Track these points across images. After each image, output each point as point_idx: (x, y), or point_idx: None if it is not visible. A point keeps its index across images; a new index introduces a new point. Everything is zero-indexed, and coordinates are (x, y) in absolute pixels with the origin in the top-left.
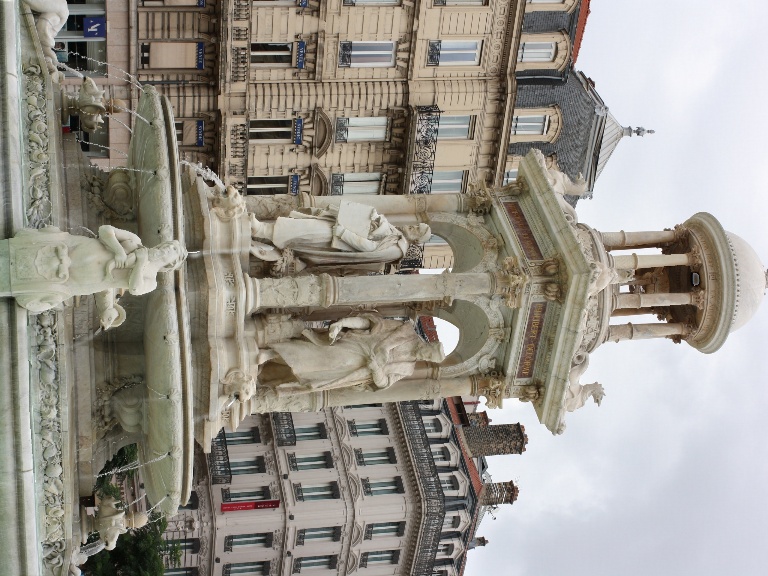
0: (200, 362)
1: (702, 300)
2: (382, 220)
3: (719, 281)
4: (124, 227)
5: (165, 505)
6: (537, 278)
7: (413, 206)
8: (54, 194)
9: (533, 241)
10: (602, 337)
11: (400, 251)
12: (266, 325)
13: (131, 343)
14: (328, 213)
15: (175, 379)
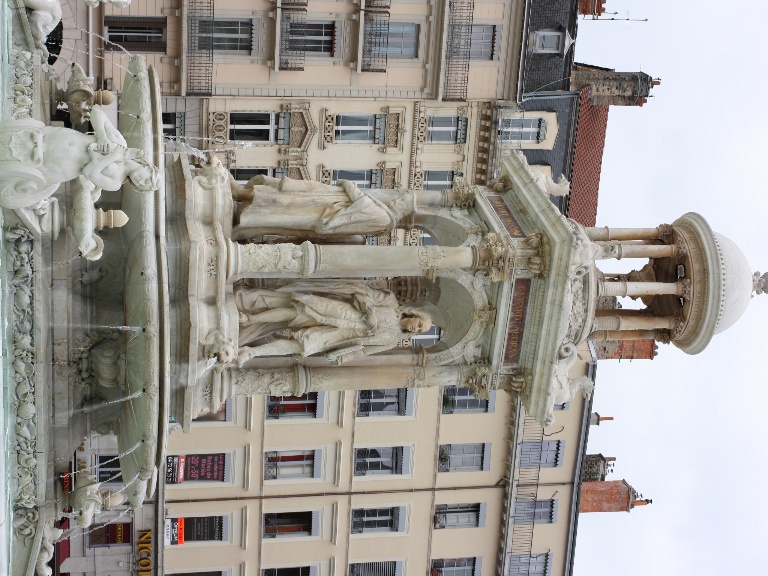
0: None
1: None
2: None
3: None
4: None
5: (135, 103)
6: None
7: None
8: None
9: None
10: (585, 235)
11: None
12: None
13: None
14: None
15: None
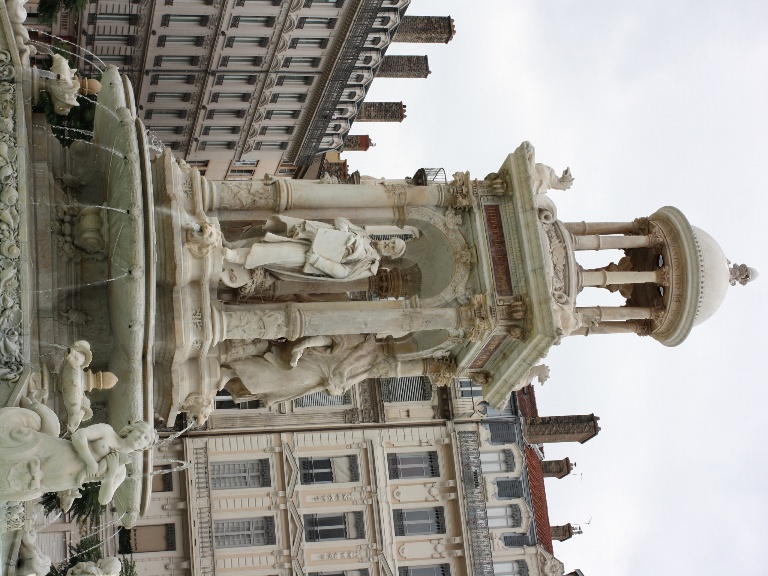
0: (162, 392)
1: (661, 318)
2: (358, 243)
3: (682, 303)
4: (94, 267)
5: None
6: (502, 322)
7: (392, 202)
8: (25, 303)
9: (506, 267)
10: None
11: (372, 274)
12: (230, 350)
13: (95, 369)
14: (304, 236)
15: (137, 461)
